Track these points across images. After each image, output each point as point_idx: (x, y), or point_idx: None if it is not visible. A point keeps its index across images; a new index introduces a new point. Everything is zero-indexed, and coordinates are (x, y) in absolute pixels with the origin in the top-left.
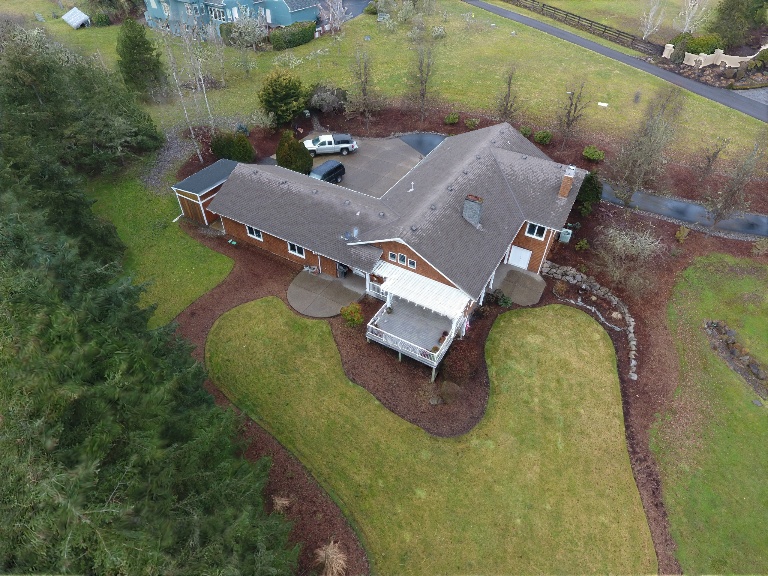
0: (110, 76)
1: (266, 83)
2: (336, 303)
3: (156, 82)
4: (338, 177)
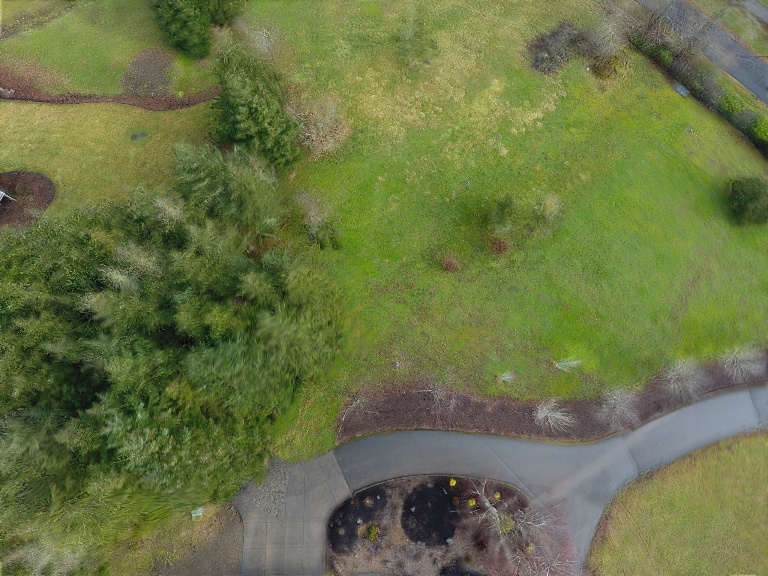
0: None
1: None
2: None
3: None
4: None
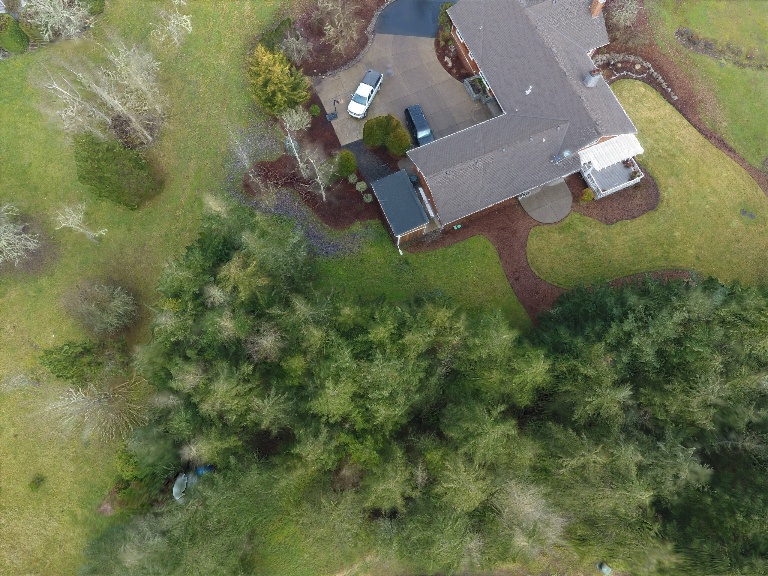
0: (221, 212)
1: (260, 82)
2: (563, 199)
3: None
4: None
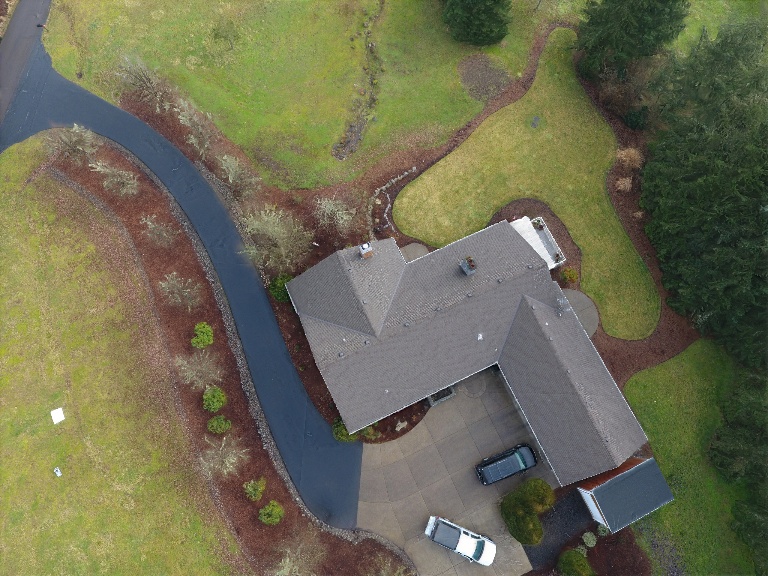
0: None
1: None
2: (569, 299)
3: None
4: None
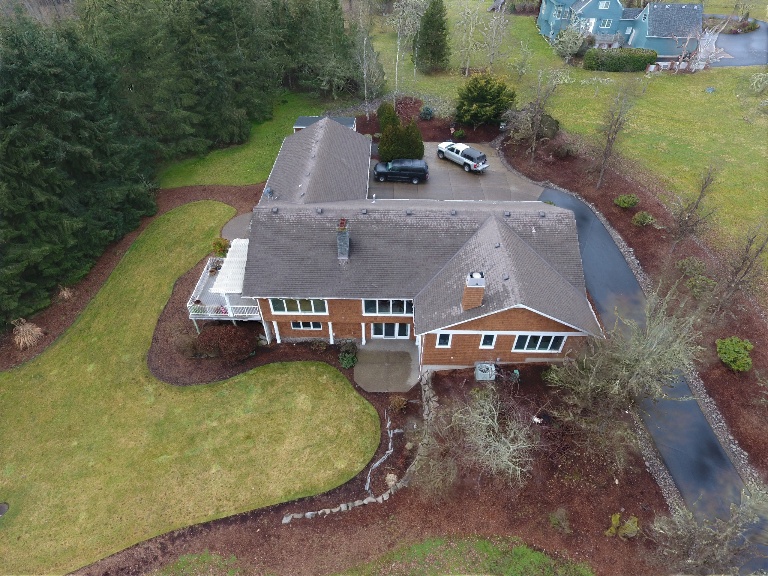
0: (362, 33)
1: None
2: None
3: (431, 56)
4: (415, 178)
